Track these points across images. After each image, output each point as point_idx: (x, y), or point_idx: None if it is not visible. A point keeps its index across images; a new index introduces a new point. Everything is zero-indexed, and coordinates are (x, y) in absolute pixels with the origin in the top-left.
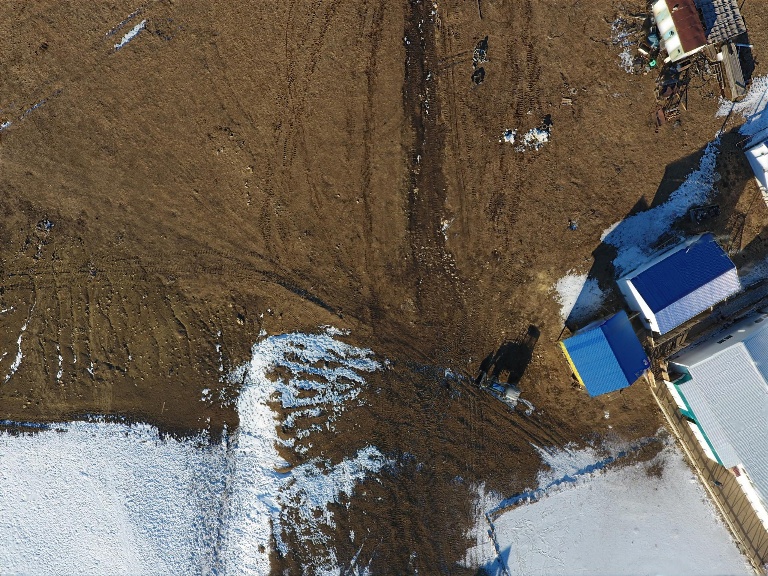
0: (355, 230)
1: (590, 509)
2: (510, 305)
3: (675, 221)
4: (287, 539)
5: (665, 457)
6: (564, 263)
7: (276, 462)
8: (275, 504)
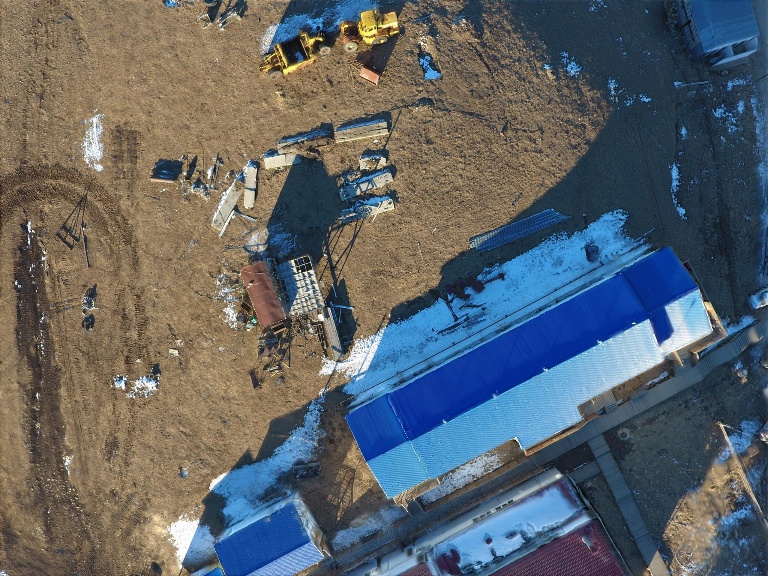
0: None
1: None
2: (132, 541)
3: (281, 475)
4: None
5: None
6: (176, 508)
7: None
8: None
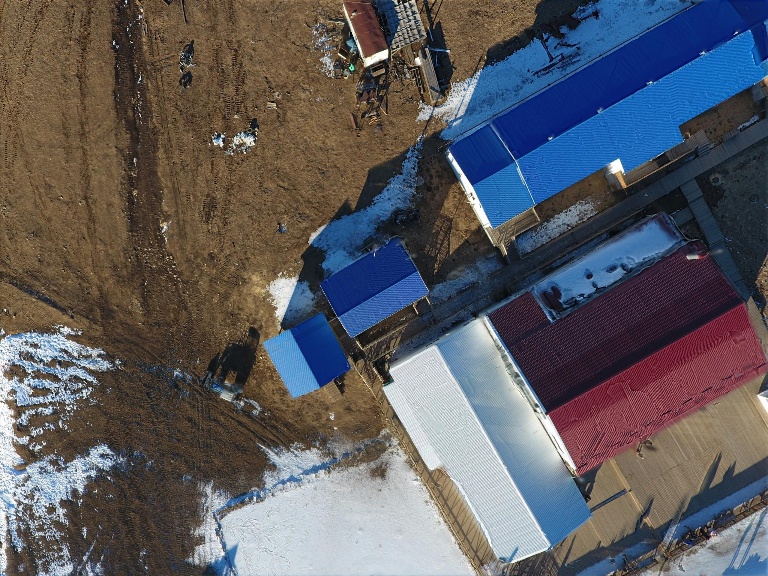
0: (80, 231)
1: (315, 509)
2: (230, 307)
3: (379, 225)
4: (22, 535)
5: (388, 458)
6: (275, 266)
7: (14, 459)
8: (11, 500)
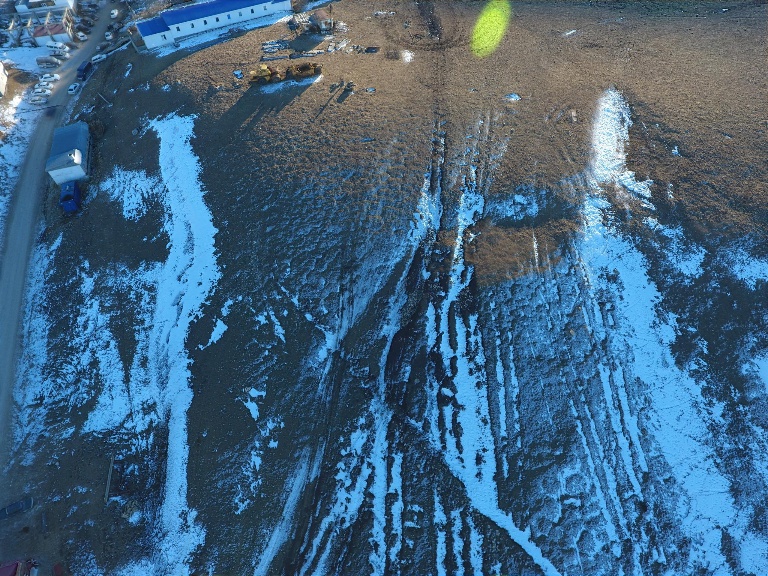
0: None
1: None
2: None
3: None
4: None
5: None
6: None
7: None
8: None
